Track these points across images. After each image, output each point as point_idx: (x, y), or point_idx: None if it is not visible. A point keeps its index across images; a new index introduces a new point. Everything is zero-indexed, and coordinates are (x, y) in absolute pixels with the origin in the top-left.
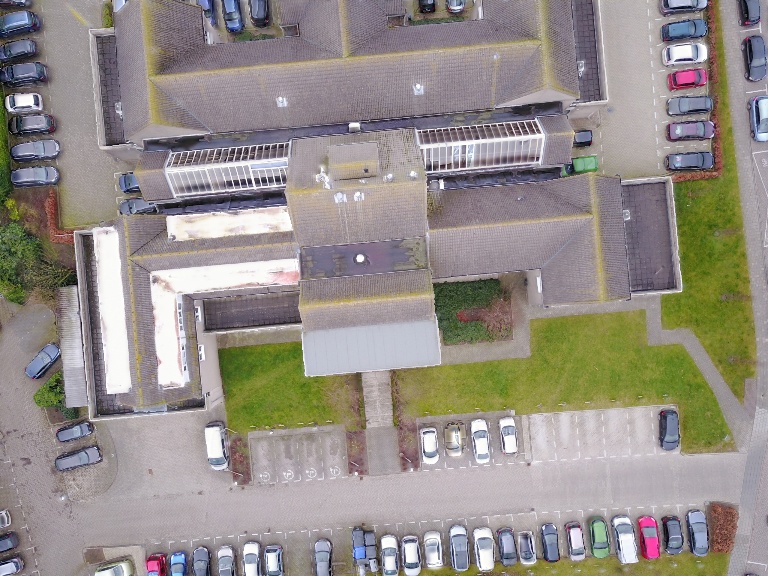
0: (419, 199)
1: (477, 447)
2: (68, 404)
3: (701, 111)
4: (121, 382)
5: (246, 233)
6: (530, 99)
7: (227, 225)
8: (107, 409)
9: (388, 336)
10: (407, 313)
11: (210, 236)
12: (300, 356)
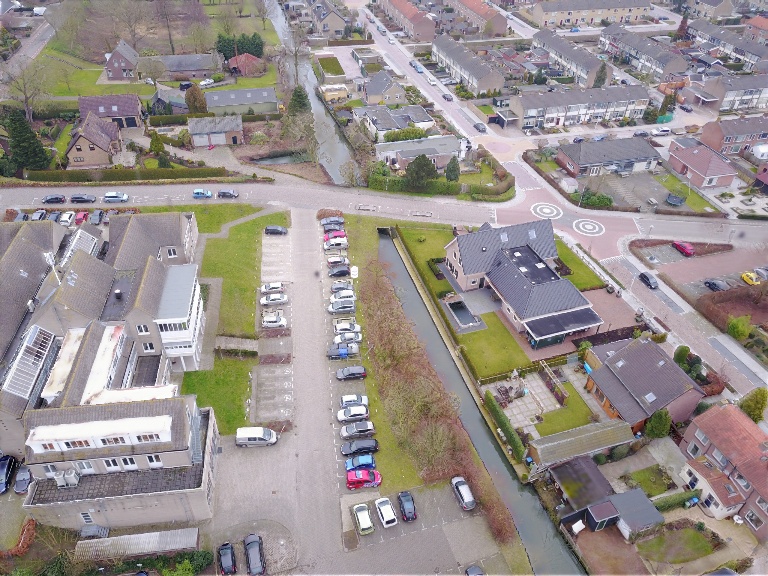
0: (89, 257)
1: (276, 298)
2: (192, 545)
3: (102, 213)
4: (162, 422)
5: (76, 352)
6: (57, 239)
7: (65, 362)
8: (197, 484)
9: (173, 284)
10: (159, 271)
11: (69, 371)
12: (194, 383)
